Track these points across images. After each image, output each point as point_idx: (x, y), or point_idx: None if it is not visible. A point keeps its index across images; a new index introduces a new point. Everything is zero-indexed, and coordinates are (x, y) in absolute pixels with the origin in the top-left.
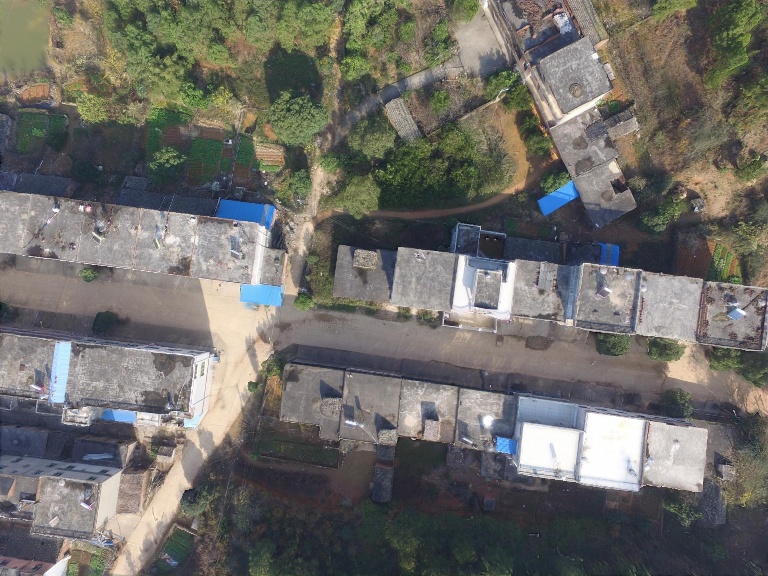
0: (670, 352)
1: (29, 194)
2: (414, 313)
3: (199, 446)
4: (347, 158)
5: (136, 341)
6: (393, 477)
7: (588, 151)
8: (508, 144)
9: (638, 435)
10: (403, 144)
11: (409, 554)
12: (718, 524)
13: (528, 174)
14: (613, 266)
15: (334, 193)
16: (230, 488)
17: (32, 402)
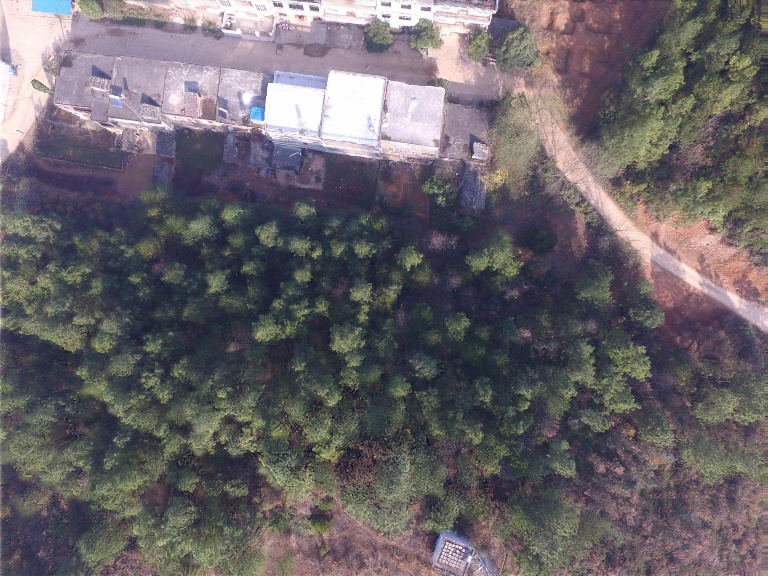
0: (423, 33)
1: None
2: (199, 24)
3: None
4: None
5: None
6: (174, 176)
7: None
8: None
9: (379, 95)
10: None
11: (153, 201)
12: (479, 211)
13: None
14: None
15: None
16: (13, 179)
17: None
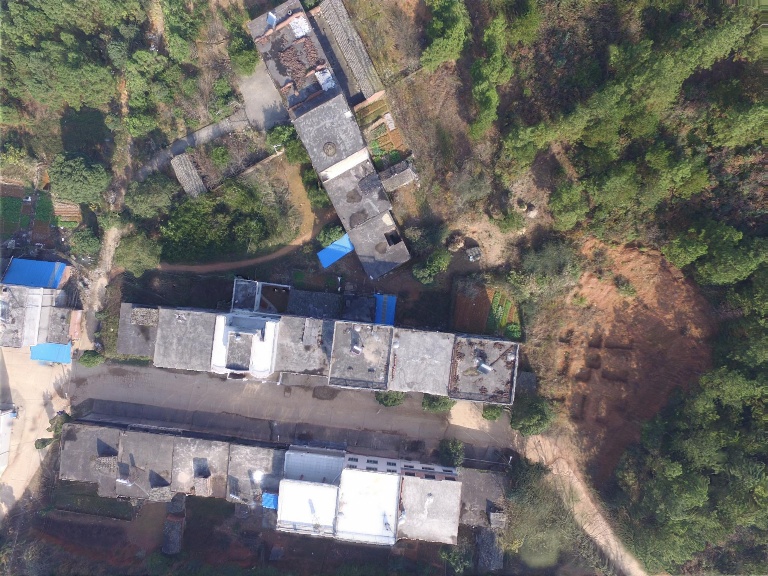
0: (436, 404)
1: None
2: None
3: None
4: None
5: None
6: (185, 528)
7: (362, 204)
8: (294, 196)
9: (393, 489)
10: (185, 200)
11: None
12: (497, 569)
13: (314, 225)
14: (365, 324)
15: None
16: (21, 543)
17: None
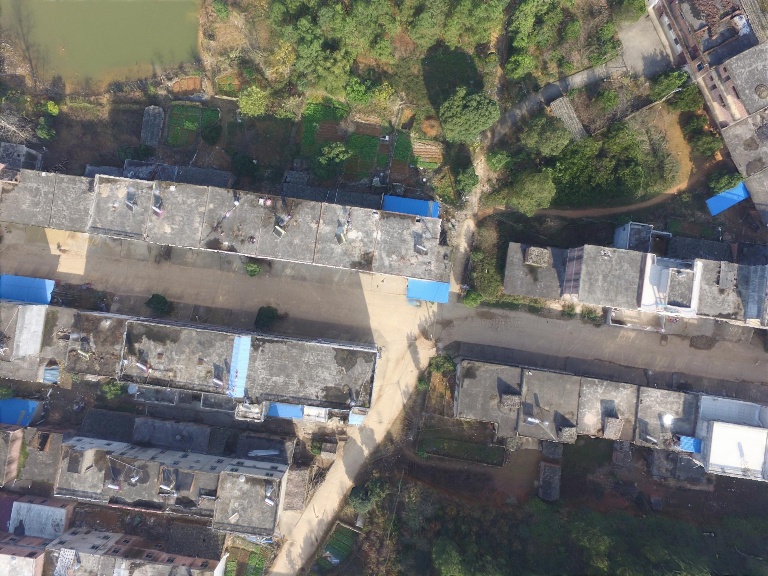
0: None
1: (206, 187)
2: (578, 311)
3: (360, 443)
4: (509, 156)
5: (296, 337)
6: None
7: (759, 152)
8: (671, 144)
9: None
10: (571, 142)
11: (602, 552)
12: None
13: (691, 174)
14: None
15: (495, 190)
16: None
17: None
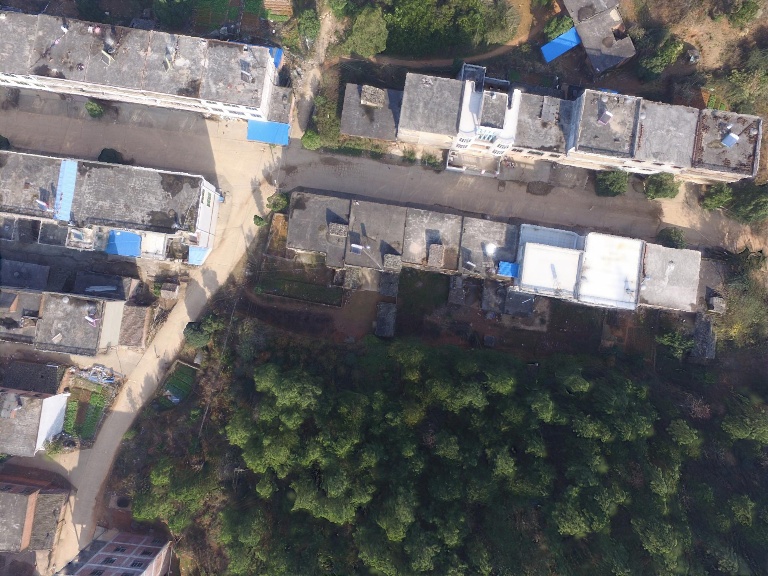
0: (666, 186)
1: None
2: (419, 157)
3: (203, 285)
4: (355, 7)
5: None
6: None
7: None
8: None
9: (635, 256)
10: None
11: (413, 364)
12: (708, 360)
13: (532, 26)
14: None
15: (342, 41)
16: (234, 320)
17: None
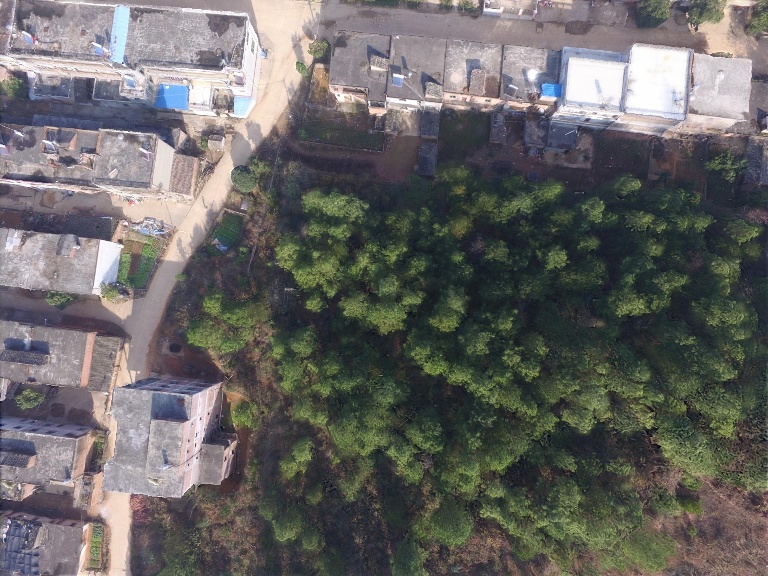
0: (711, 5)
1: None
2: (455, 4)
3: (247, 138)
4: None
5: None
6: (437, 157)
7: None
8: None
9: (682, 68)
10: None
11: (459, 179)
12: (762, 187)
13: None
14: None
15: None
16: (279, 162)
17: (88, 96)
